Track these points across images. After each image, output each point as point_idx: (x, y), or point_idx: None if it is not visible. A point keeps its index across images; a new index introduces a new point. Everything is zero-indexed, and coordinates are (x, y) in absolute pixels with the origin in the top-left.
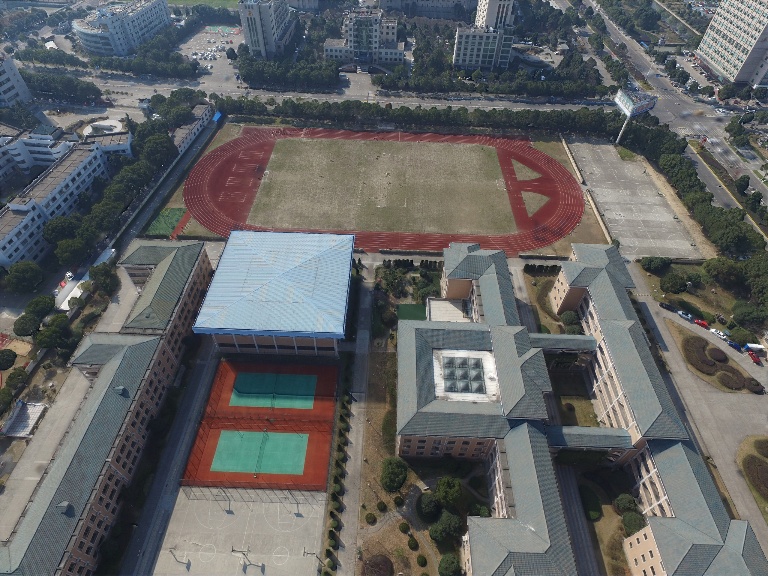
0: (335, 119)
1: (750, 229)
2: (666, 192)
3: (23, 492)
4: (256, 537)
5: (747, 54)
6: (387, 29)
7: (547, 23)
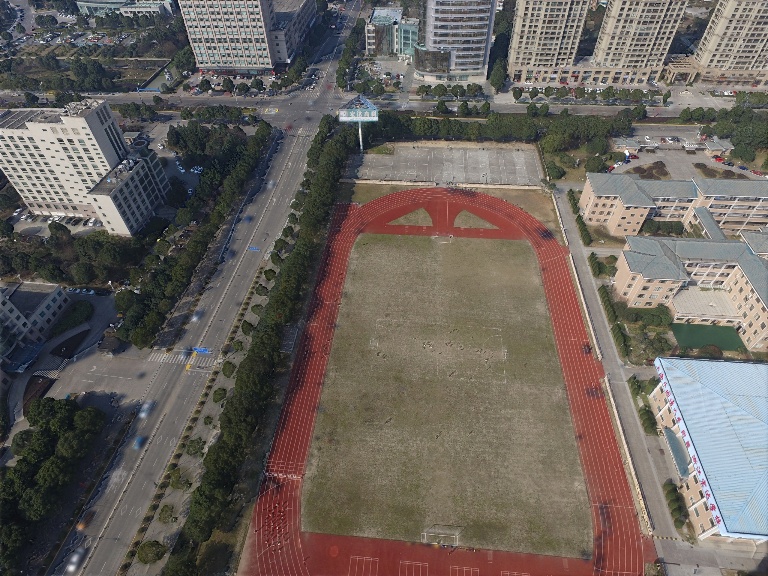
0: None
1: (513, 118)
2: (445, 145)
3: None
4: None
5: (265, 42)
6: None
7: None
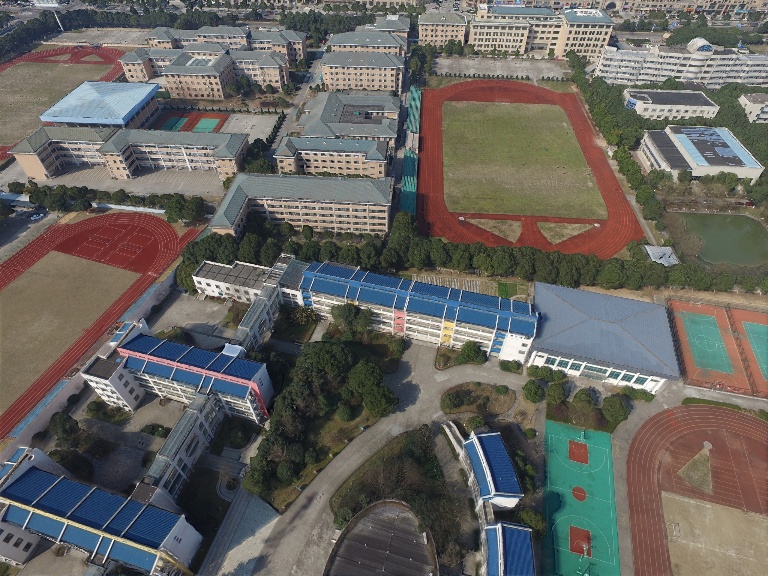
0: None
1: None
2: (120, 29)
3: (187, 188)
4: (241, 127)
5: None
6: None
7: None
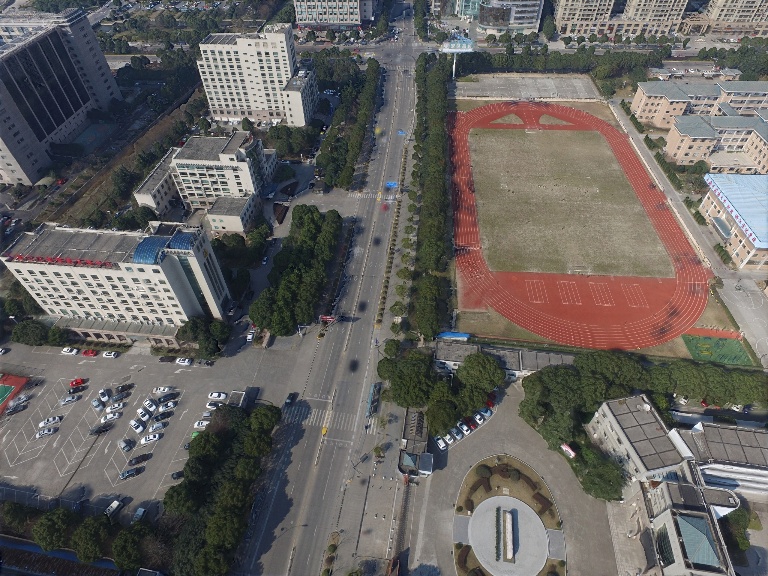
0: None
1: None
2: (517, 75)
3: None
4: None
5: (357, 1)
6: None
7: None
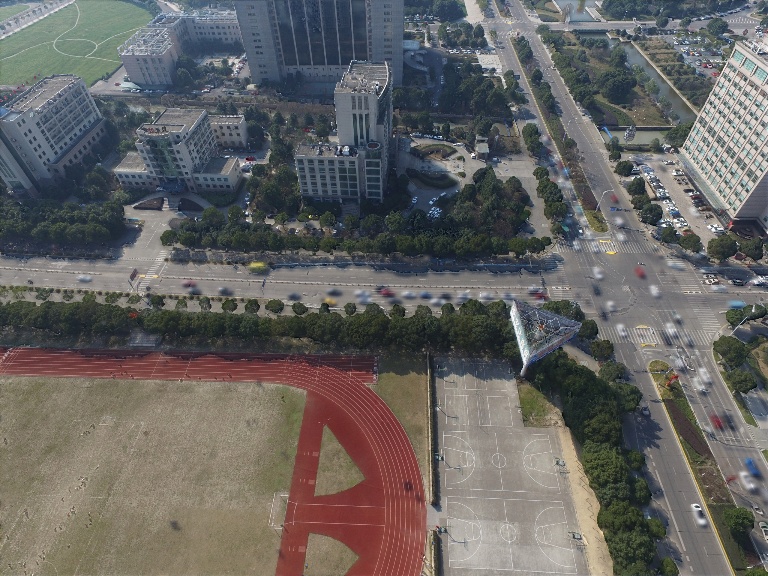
0: (60, 332)
1: None
2: (590, 530)
3: None
4: None
5: (755, 182)
6: (228, 129)
7: (471, 101)
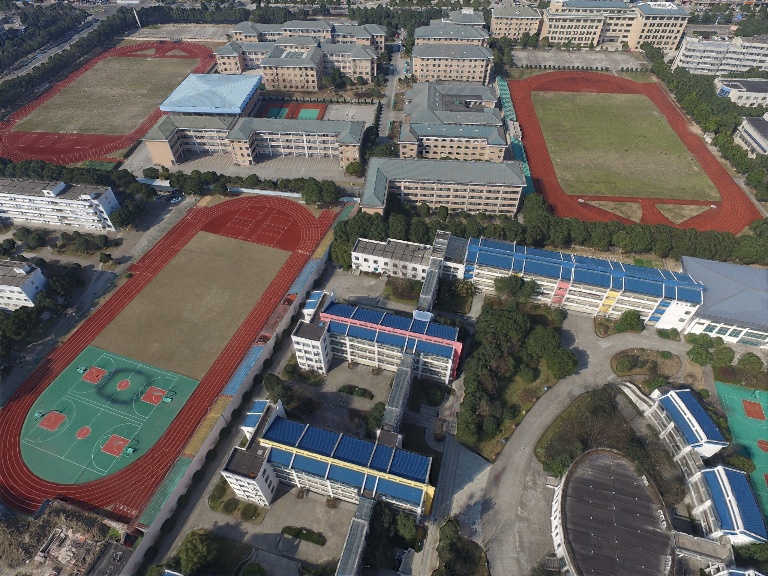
0: None
1: None
2: (194, 25)
3: (309, 173)
4: (343, 117)
5: None
6: None
7: None
